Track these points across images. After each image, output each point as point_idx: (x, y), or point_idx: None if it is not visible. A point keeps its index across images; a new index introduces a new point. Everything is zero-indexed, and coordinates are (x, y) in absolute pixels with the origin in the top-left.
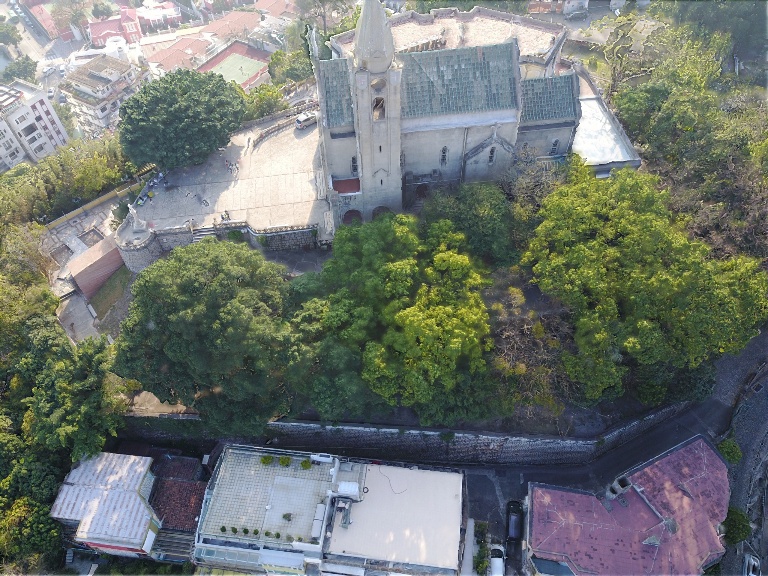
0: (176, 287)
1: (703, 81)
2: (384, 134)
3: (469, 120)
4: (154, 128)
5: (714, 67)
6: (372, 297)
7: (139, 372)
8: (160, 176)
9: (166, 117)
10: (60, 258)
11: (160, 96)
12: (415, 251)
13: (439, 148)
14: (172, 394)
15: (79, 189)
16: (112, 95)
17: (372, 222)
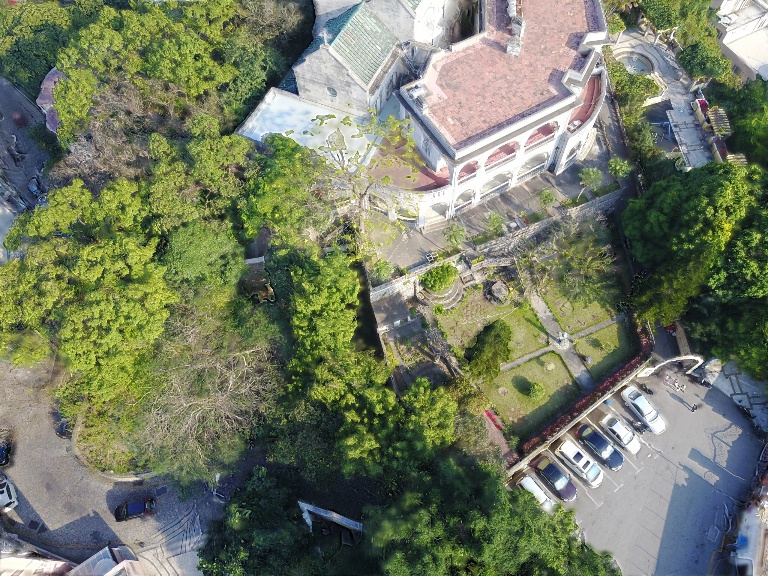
0: None
1: None
2: None
3: None
4: None
5: None
6: None
7: None
8: None
9: None
10: None
11: None
12: None
13: None
14: None
15: None
16: None
17: None
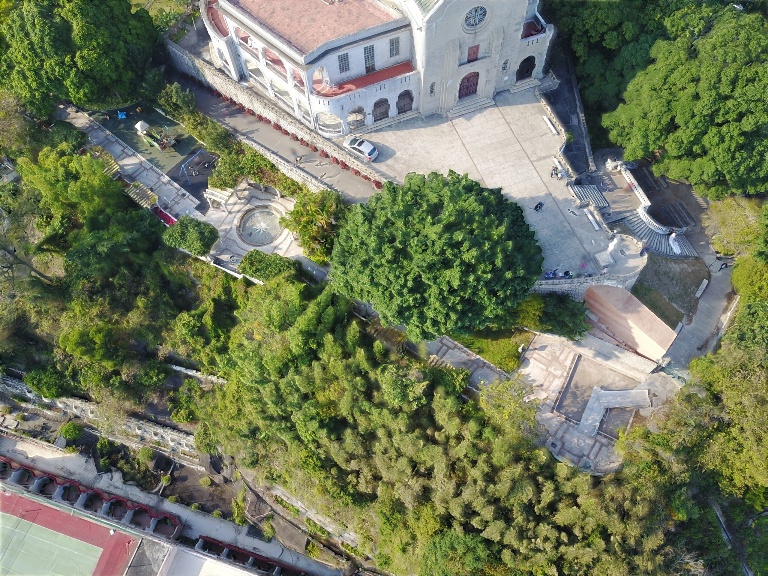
0: (767, 57)
1: None
2: None
3: None
4: (505, 234)
5: None
6: None
7: None
8: None
9: None
10: (619, 426)
11: None
12: None
13: None
14: None
15: None
16: None
17: (561, 7)
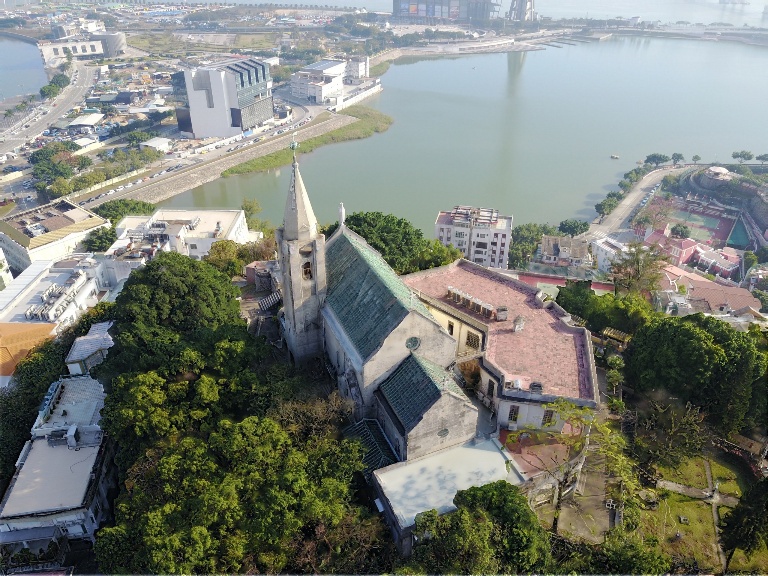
0: None
1: None
2: None
3: None
4: None
5: None
6: None
7: None
8: None
9: None
10: None
11: (360, 218)
12: None
13: None
14: None
15: None
16: (551, 264)
17: (260, 345)
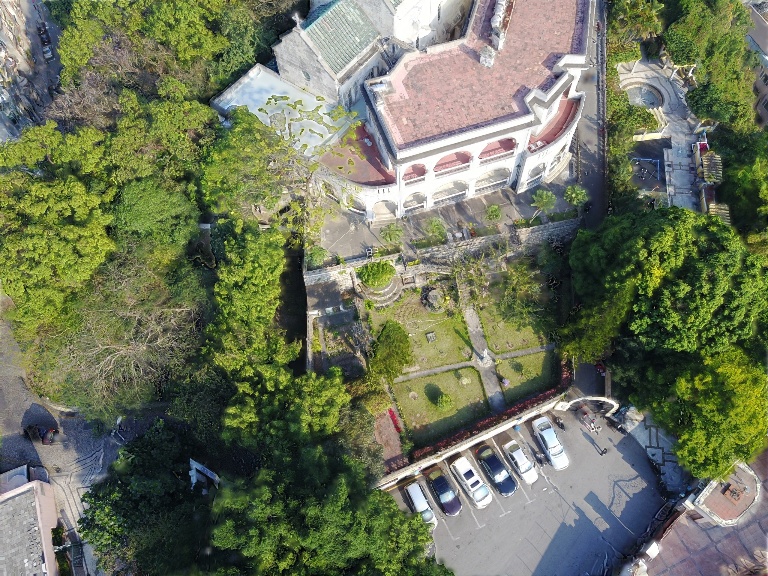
0: None
1: None
2: None
3: None
4: None
5: None
6: None
7: None
8: None
9: None
10: None
11: None
12: None
13: None
14: None
15: None
16: None
17: None
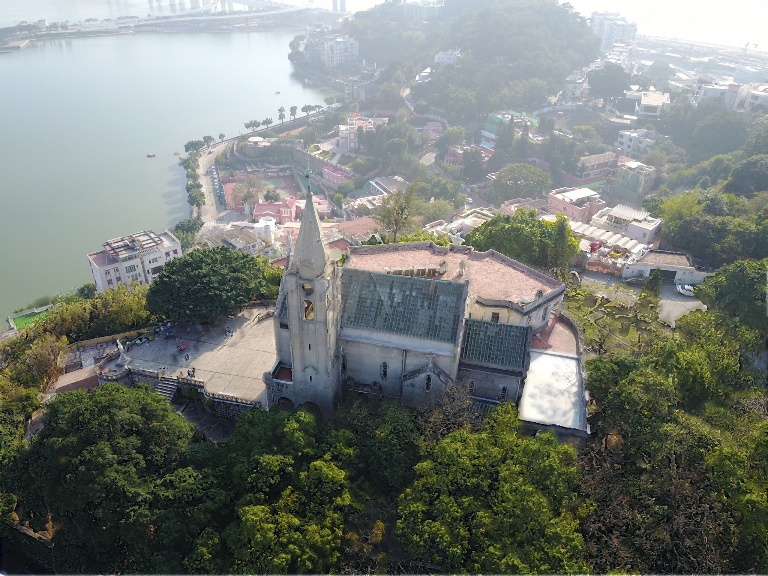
0: (68, 415)
1: (716, 372)
2: (313, 334)
3: (408, 343)
4: (173, 285)
5: (731, 361)
6: (235, 483)
7: (8, 483)
8: (168, 325)
9: (185, 279)
10: None
11: (191, 262)
12: (300, 452)
13: (379, 362)
14: (32, 516)
15: (114, 320)
16: None
17: (288, 413)
